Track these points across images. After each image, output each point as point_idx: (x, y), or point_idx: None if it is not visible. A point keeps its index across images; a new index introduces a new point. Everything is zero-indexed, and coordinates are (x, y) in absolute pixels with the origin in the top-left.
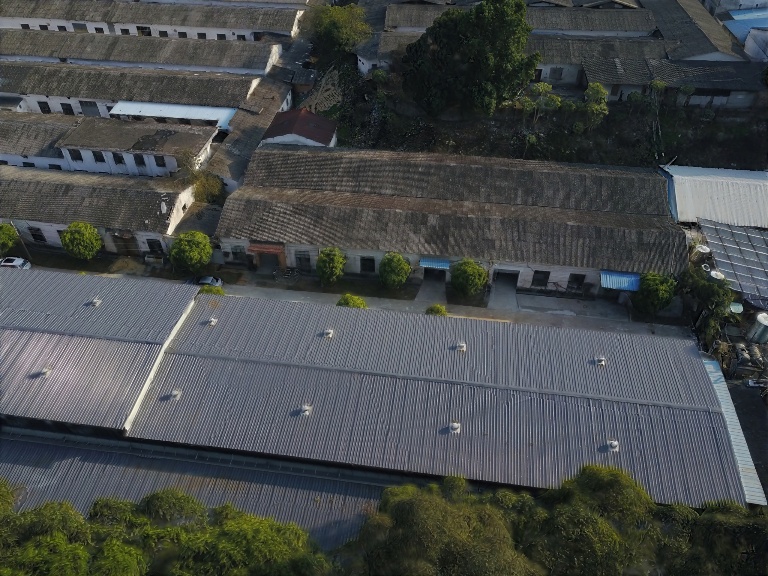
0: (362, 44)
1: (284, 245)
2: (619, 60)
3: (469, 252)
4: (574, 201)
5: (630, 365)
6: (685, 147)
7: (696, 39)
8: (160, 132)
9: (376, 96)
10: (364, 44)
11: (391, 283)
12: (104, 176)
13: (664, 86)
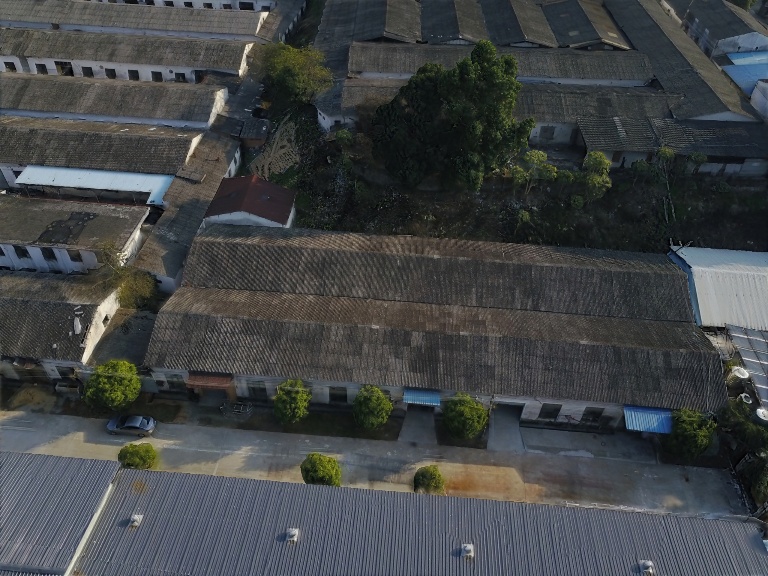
0: (322, 94)
1: (233, 376)
2: (619, 119)
3: (464, 383)
4: (582, 304)
5: (684, 571)
6: (696, 222)
7: (702, 94)
8: (75, 216)
9: (340, 159)
10: (325, 94)
11: (369, 427)
12: (3, 276)
13: (674, 154)
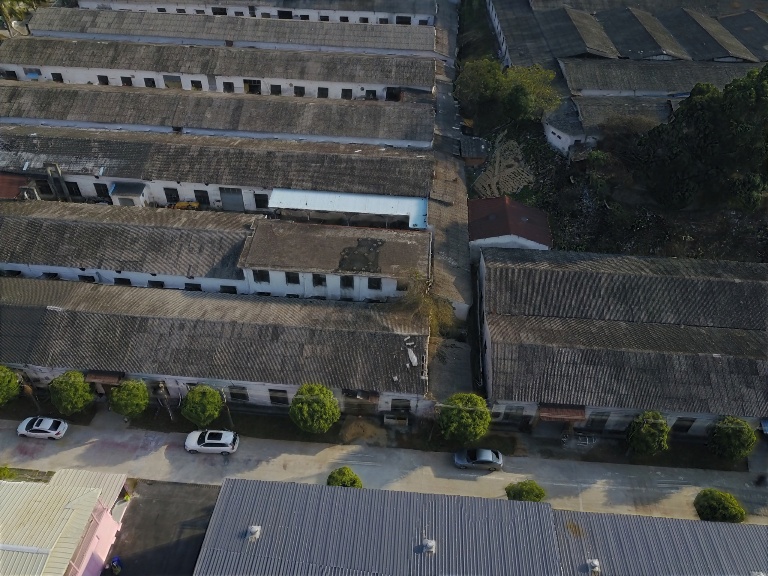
0: (552, 113)
1: (584, 408)
2: None
3: None
4: None
5: None
6: None
7: None
8: (363, 242)
9: (584, 179)
10: (554, 113)
11: (737, 459)
12: (306, 305)
13: None
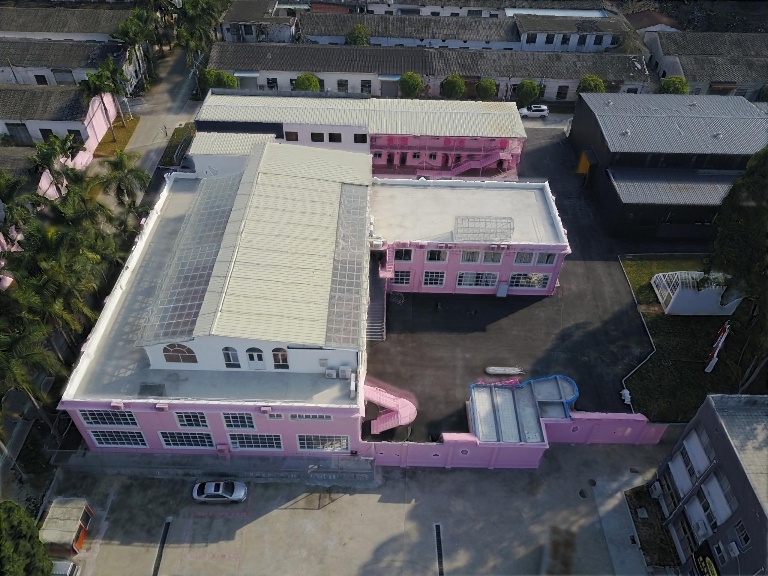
0: None
1: None
2: None
3: None
4: None
5: None
6: None
7: None
8: (585, 21)
9: (693, 0)
10: None
11: None
12: None
13: None
